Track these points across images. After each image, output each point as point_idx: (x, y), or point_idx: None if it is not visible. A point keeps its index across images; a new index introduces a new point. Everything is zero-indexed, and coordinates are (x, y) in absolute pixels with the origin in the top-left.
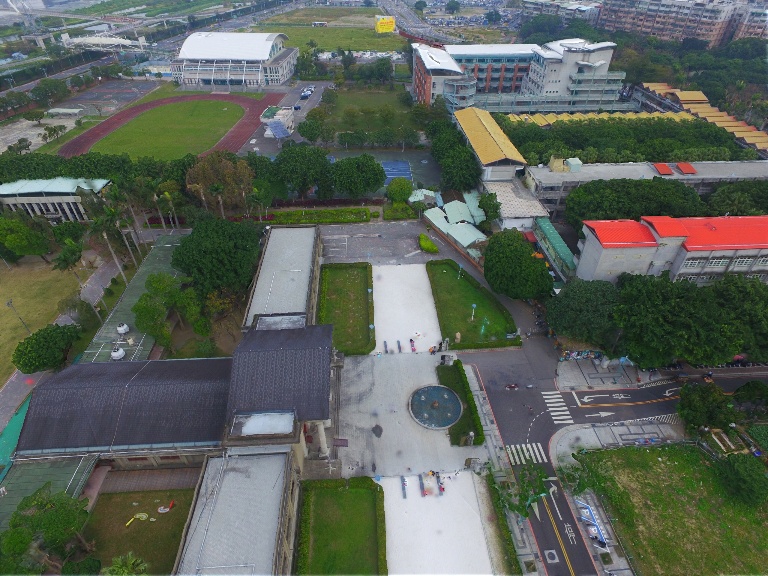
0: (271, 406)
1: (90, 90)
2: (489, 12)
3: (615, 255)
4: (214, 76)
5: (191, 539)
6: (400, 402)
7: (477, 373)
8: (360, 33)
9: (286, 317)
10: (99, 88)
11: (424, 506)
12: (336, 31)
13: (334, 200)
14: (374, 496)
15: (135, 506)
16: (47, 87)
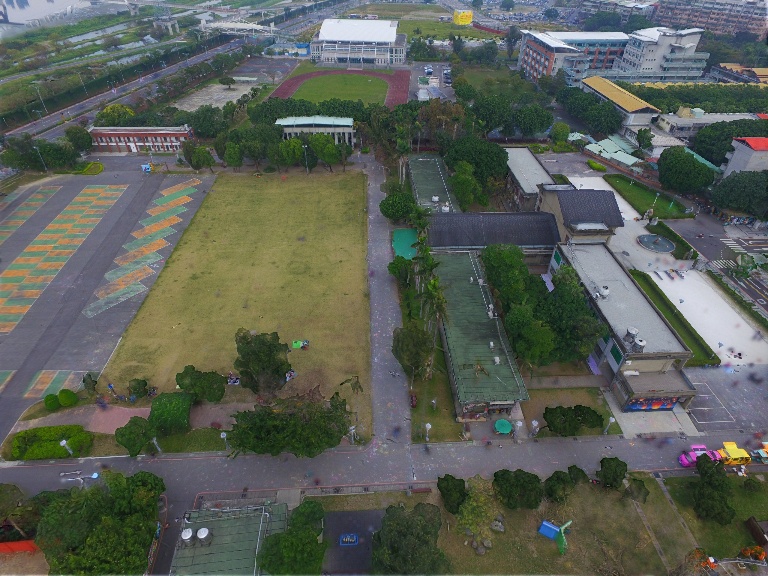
0: (589, 219)
1: (243, 65)
2: (548, 9)
3: (761, 157)
4: (349, 55)
5: None
6: (631, 242)
7: None
8: (439, 25)
9: (558, 186)
10: (250, 64)
11: (675, 283)
12: (416, 23)
13: (511, 139)
14: (643, 279)
15: None
16: (223, 60)
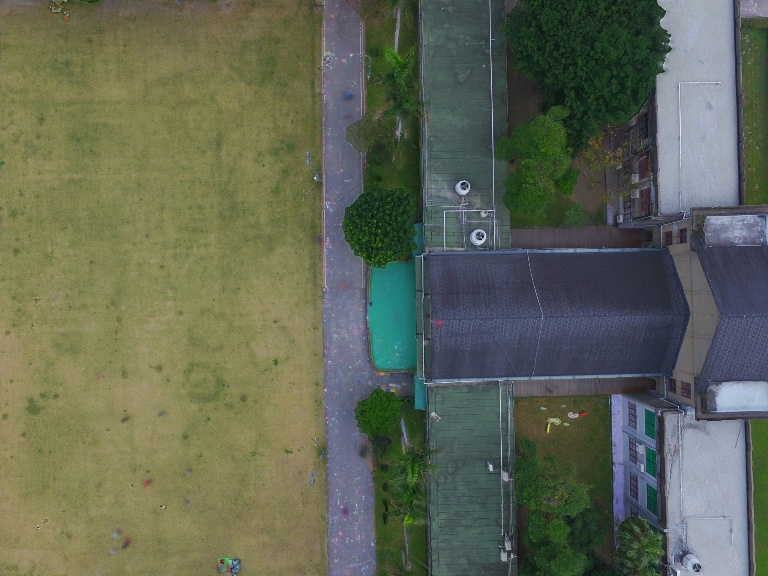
0: (751, 377)
1: None
2: None
3: None
4: None
5: (669, 494)
6: None
7: None
8: None
9: (739, 216)
10: None
11: None
12: None
13: None
14: None
15: (545, 411)
16: None
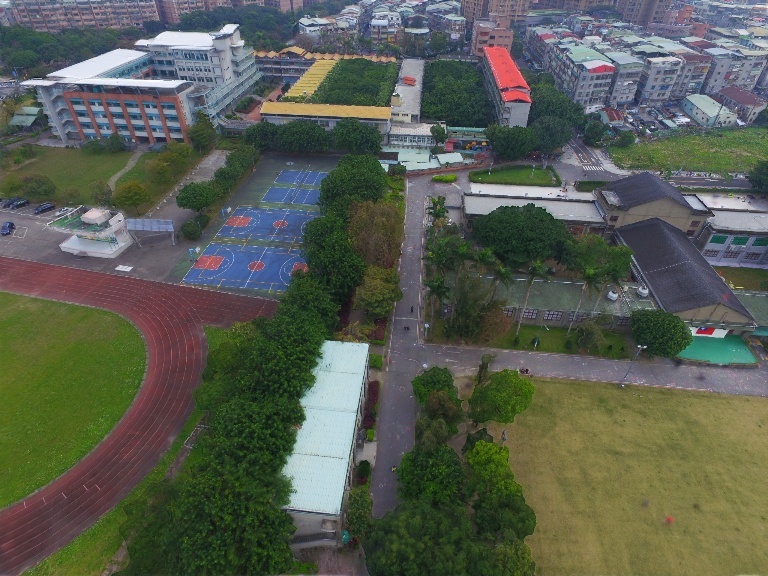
0: None
1: None
2: None
3: None
4: None
5: None
6: None
7: None
8: None
9: None
10: None
11: None
12: None
13: None
14: None
15: None
16: None
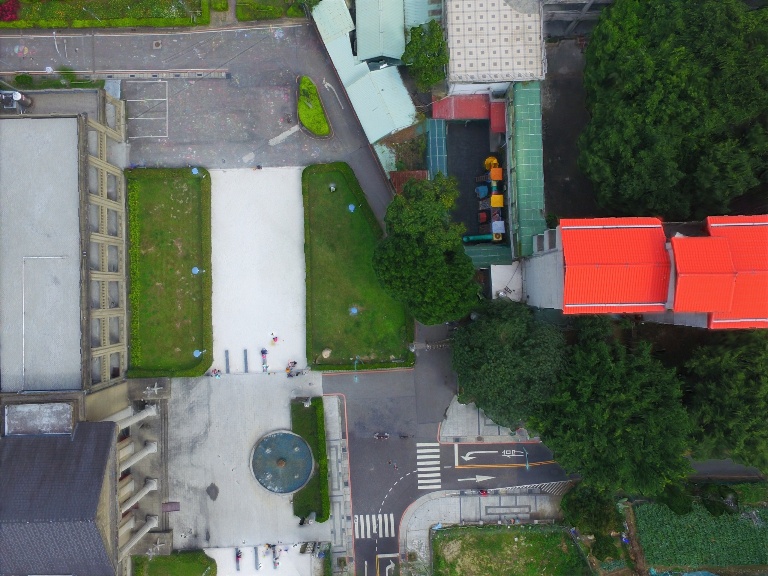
0: (44, 573)
1: None
2: None
3: None
4: None
5: None
6: (241, 454)
7: (343, 410)
8: None
9: (45, 404)
10: None
11: None
12: None
13: None
14: None
15: None
16: None
